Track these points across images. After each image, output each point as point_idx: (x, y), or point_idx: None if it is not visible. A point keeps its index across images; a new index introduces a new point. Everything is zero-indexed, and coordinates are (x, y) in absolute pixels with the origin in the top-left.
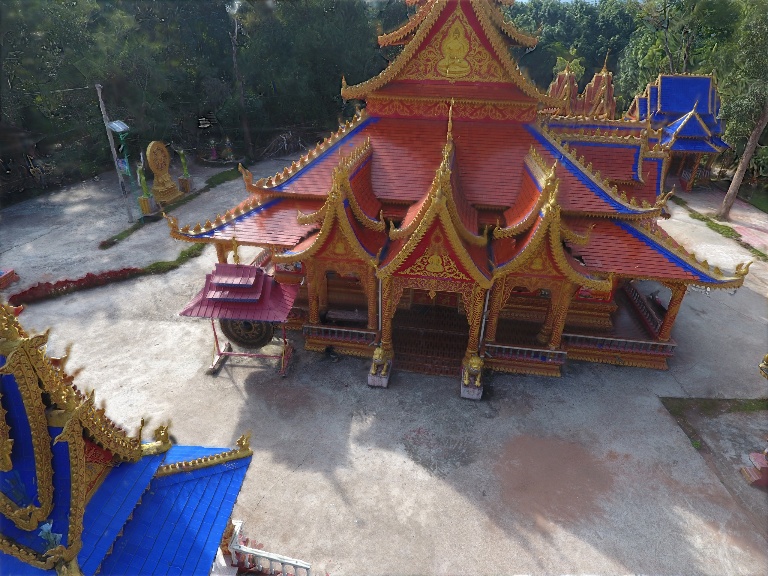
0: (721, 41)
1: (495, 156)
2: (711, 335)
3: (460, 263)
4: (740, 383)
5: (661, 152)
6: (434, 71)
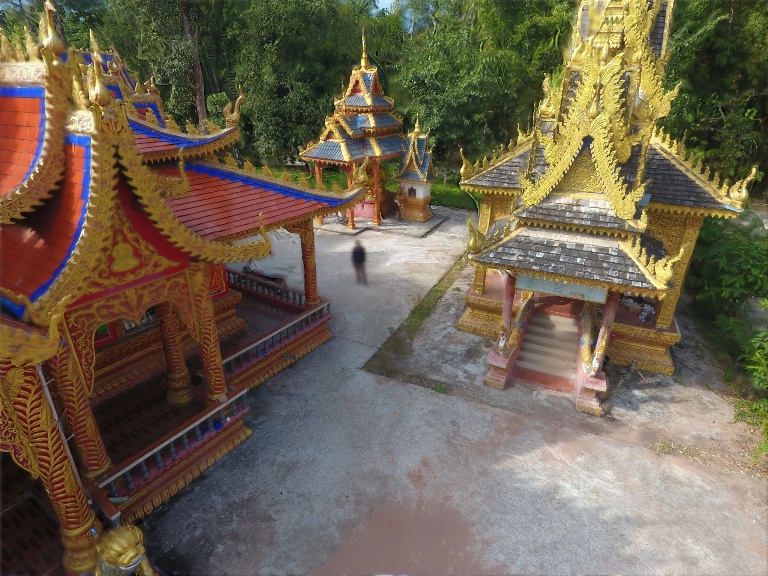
0: (94, 26)
1: None
2: (321, 283)
3: None
4: (387, 309)
5: (148, 94)
6: None
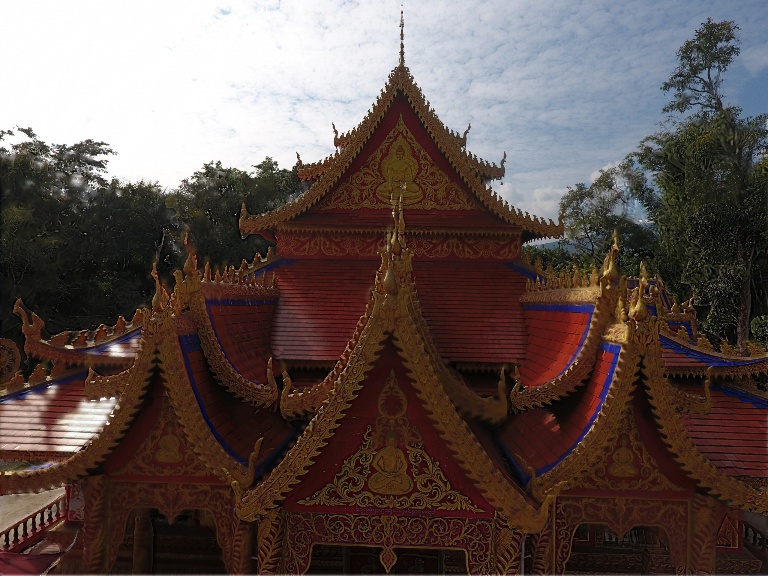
0: (645, 260)
1: (474, 298)
2: None
3: (453, 464)
4: None
5: (683, 313)
6: (373, 197)
